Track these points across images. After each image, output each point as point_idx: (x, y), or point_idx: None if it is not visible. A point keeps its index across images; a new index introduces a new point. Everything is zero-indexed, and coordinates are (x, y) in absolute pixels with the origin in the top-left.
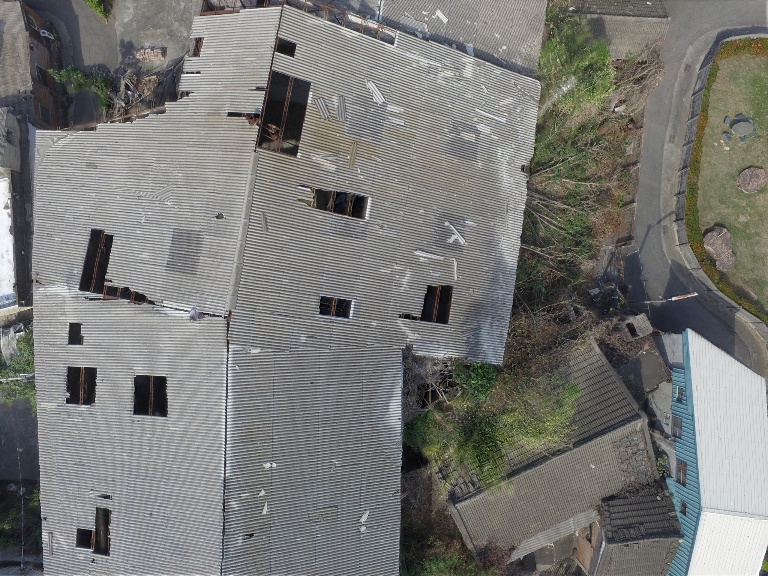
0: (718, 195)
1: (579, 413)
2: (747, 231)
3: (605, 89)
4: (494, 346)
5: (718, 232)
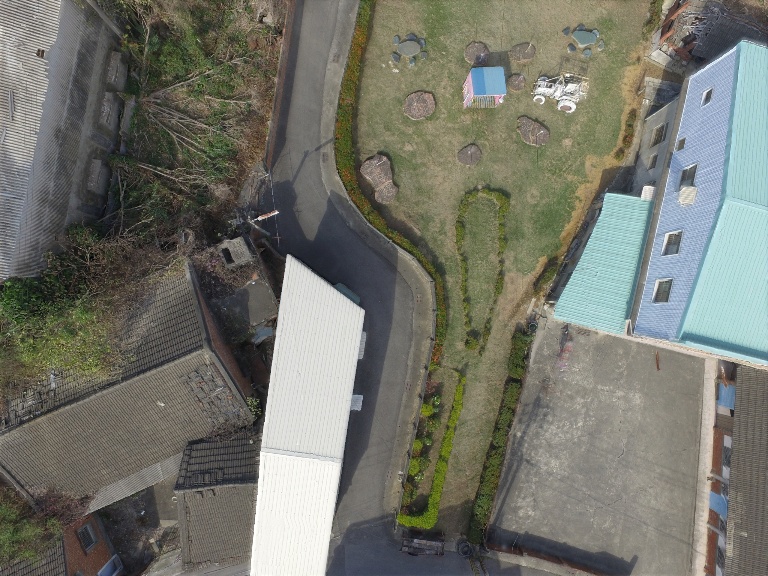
0: (384, 121)
1: (146, 344)
2: (413, 161)
3: None
4: None
5: (377, 160)
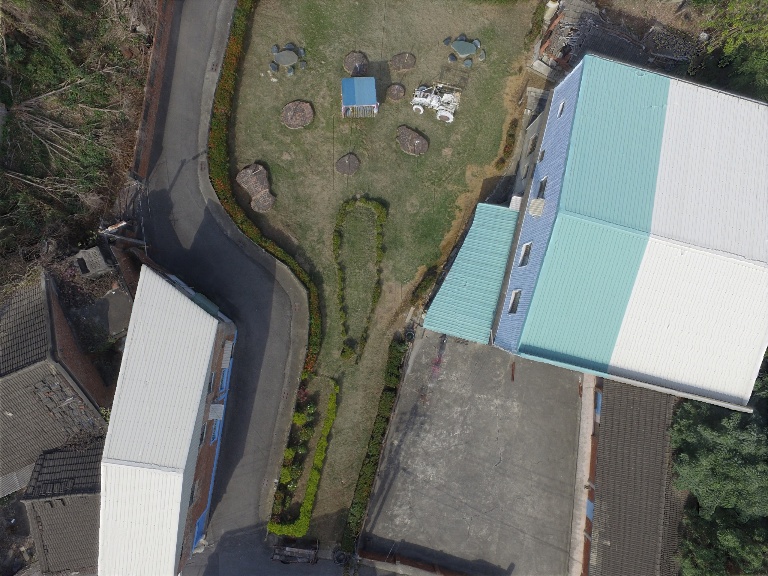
0: (262, 130)
1: None
2: (291, 170)
3: (122, 5)
4: None
5: (253, 169)
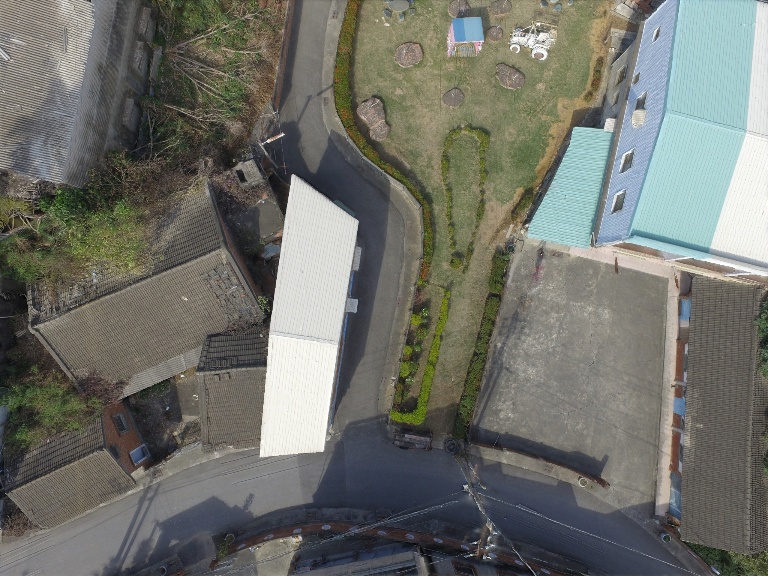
0: (377, 69)
1: (172, 247)
2: (403, 104)
3: None
4: (49, 164)
5: (371, 102)
